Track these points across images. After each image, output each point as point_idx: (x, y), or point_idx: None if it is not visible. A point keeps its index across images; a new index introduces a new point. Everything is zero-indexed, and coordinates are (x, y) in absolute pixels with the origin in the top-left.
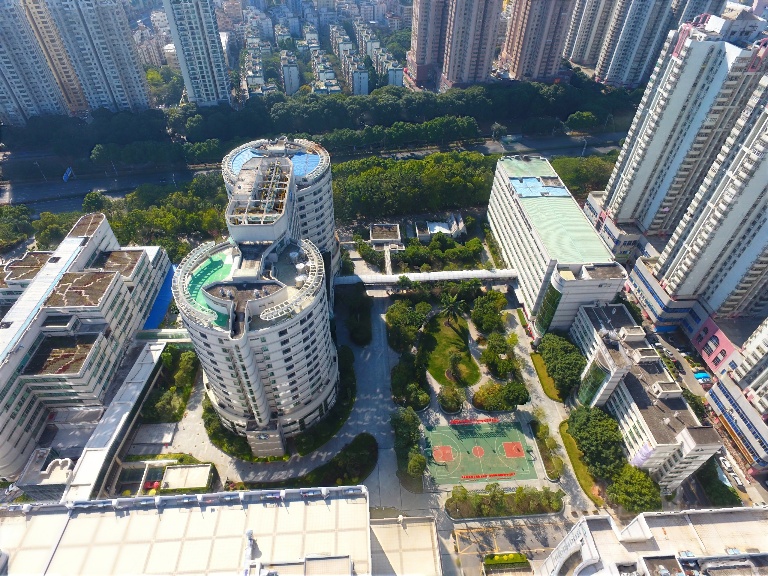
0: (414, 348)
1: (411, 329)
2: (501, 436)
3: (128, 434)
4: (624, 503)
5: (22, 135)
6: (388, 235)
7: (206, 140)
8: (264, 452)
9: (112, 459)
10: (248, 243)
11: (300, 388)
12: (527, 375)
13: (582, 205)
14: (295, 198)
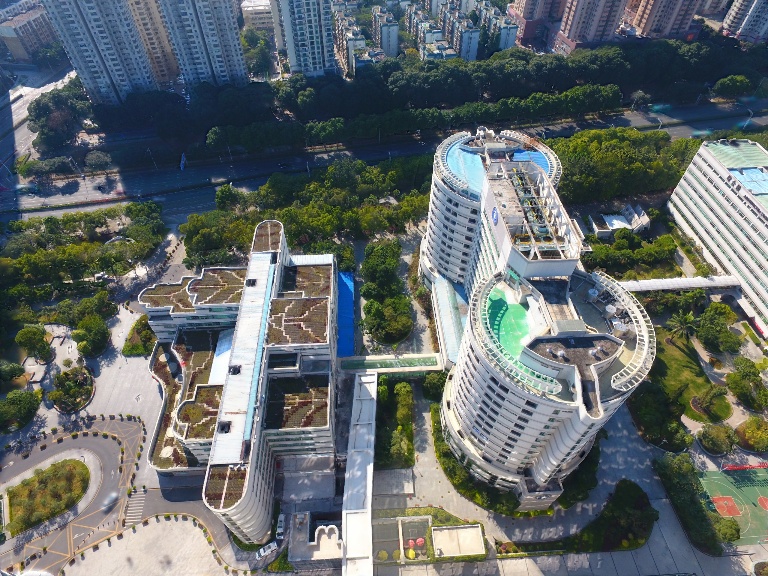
0: None
1: None
2: None
3: (372, 487)
4: None
5: (118, 115)
6: None
7: (330, 119)
8: (530, 508)
9: None
10: (537, 279)
11: None
12: None
13: None
14: None
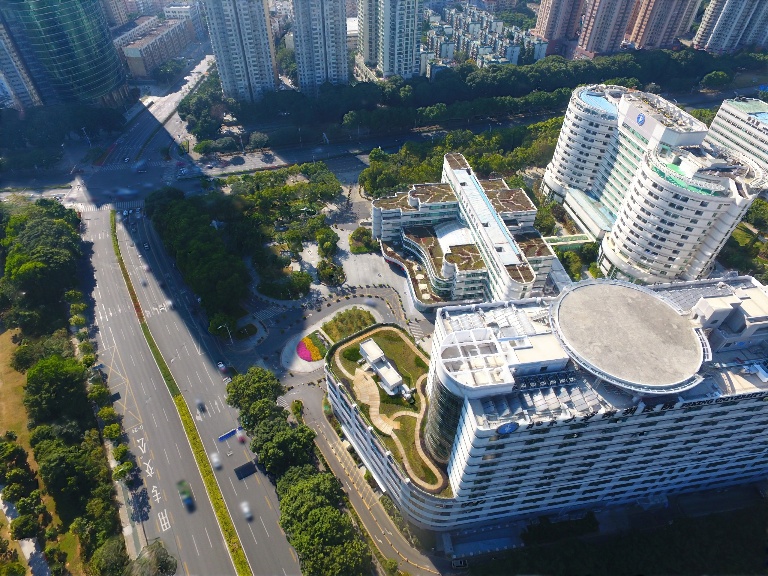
0: None
1: None
2: None
3: None
4: None
5: (257, 109)
6: None
7: None
8: None
9: None
10: None
11: None
12: None
13: None
14: None
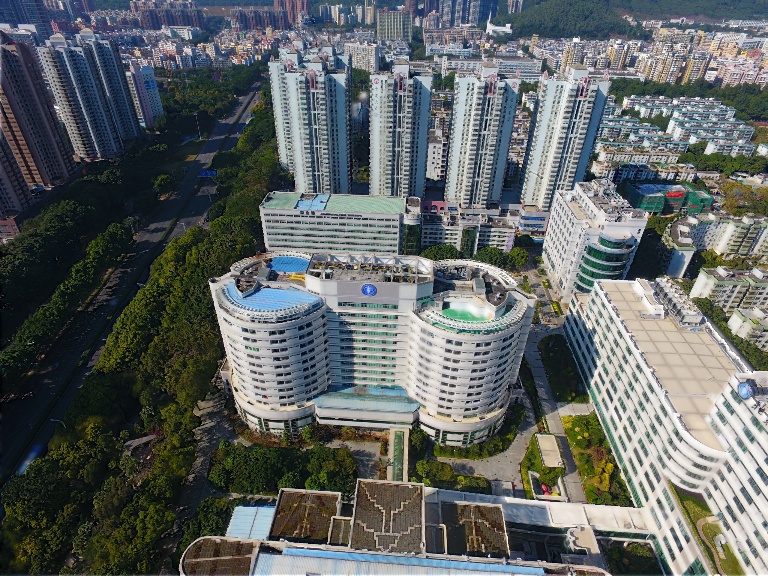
0: None
1: None
2: None
3: None
4: (525, 261)
5: None
6: None
7: None
8: None
9: None
10: None
11: None
12: None
13: None
14: None
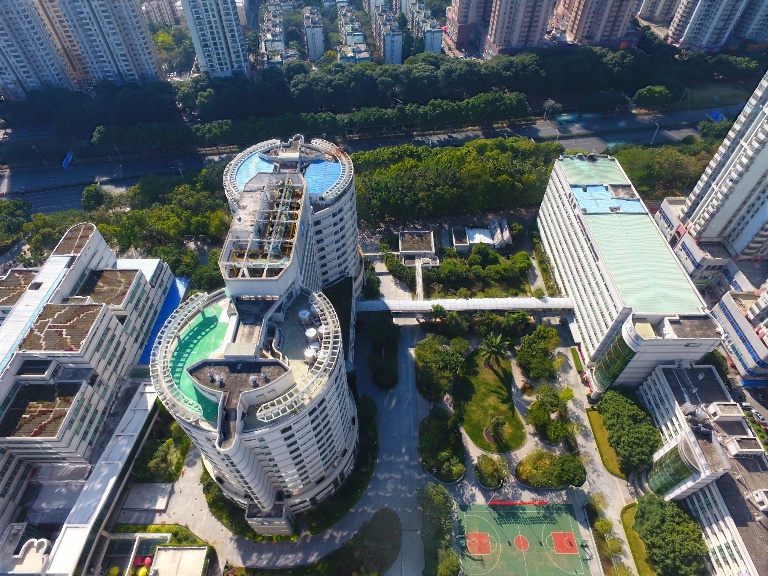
0: (447, 395)
1: (445, 375)
2: (550, 523)
3: (116, 500)
4: None
5: (22, 111)
6: (420, 246)
7: None
8: (269, 532)
9: (96, 536)
10: (247, 297)
11: (310, 470)
12: (582, 439)
13: (651, 209)
14: (309, 224)
